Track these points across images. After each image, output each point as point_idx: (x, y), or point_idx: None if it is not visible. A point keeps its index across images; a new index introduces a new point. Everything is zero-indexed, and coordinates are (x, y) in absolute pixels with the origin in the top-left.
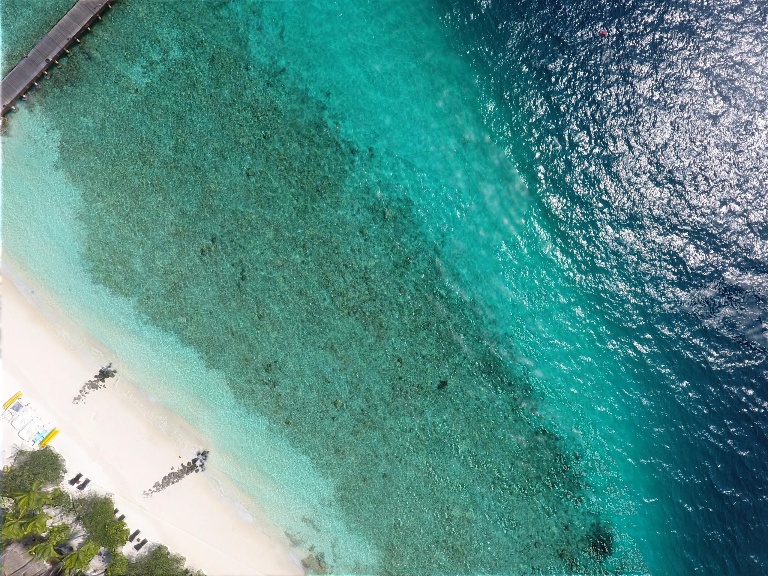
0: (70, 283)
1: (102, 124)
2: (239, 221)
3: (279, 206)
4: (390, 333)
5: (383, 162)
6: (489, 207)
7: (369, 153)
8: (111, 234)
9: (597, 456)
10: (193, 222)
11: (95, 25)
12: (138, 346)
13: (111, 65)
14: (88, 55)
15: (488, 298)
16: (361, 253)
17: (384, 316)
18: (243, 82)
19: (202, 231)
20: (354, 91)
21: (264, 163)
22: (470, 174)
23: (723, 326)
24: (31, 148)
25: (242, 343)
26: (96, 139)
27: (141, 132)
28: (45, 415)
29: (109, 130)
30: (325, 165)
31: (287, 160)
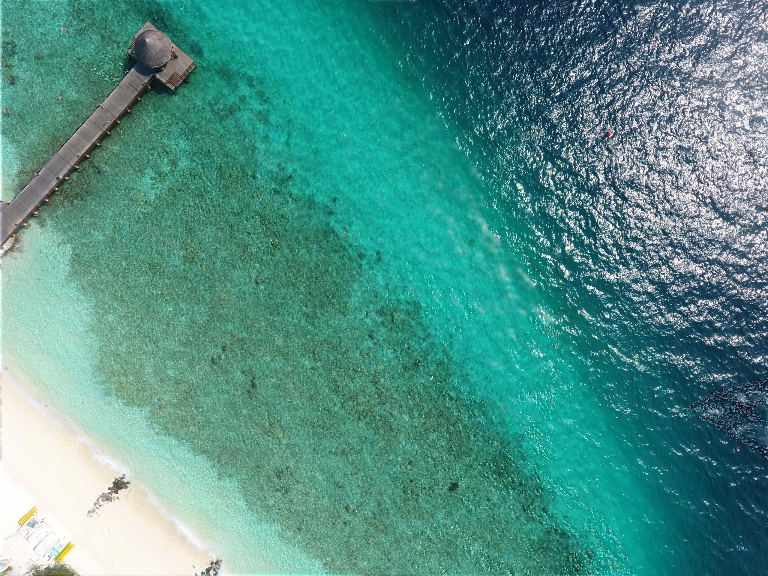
0: (83, 395)
1: (112, 237)
2: (249, 329)
3: (288, 312)
4: (400, 436)
5: (390, 265)
6: (497, 307)
7: (376, 256)
8: (122, 345)
9: (610, 554)
10: (203, 331)
11: (104, 139)
12: (151, 456)
13: (120, 178)
14: (98, 169)
15: (497, 398)
16: (370, 357)
17: (394, 419)
18: (250, 190)
19: (212, 340)
20: (360, 195)
21: (272, 270)
22: (477, 276)
23: (734, 431)
24: (43, 262)
25: (253, 450)
26: (106, 251)
27: (151, 243)
28: (60, 529)
29: (119, 242)
30: (333, 270)
31: (295, 266)
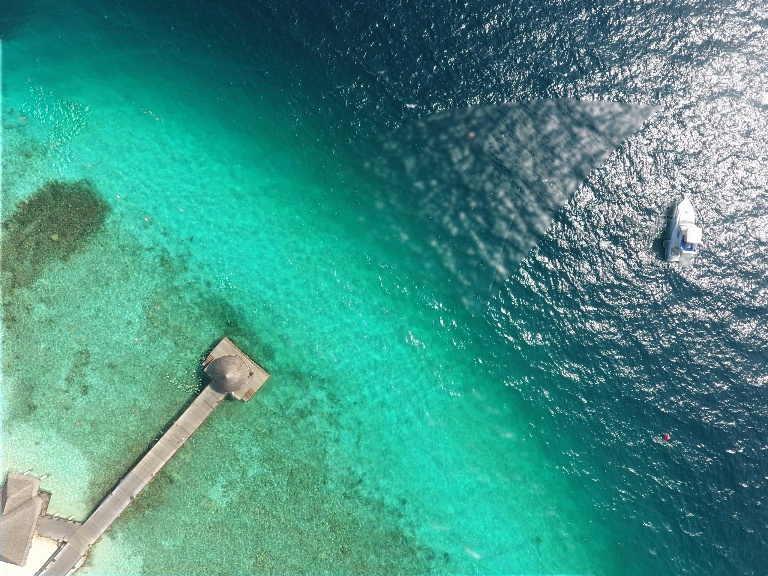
0: None
1: (183, 547)
2: None
3: None
4: None
5: (458, 567)
6: None
7: (444, 559)
8: None
9: None
10: None
11: None
12: None
13: (192, 487)
14: (169, 478)
15: None
16: None
17: None
18: (321, 496)
19: None
20: (429, 498)
21: None
22: None
23: None
24: (113, 575)
25: None
26: (177, 562)
27: (221, 553)
28: None
29: (190, 552)
30: (401, 575)
31: (364, 573)
